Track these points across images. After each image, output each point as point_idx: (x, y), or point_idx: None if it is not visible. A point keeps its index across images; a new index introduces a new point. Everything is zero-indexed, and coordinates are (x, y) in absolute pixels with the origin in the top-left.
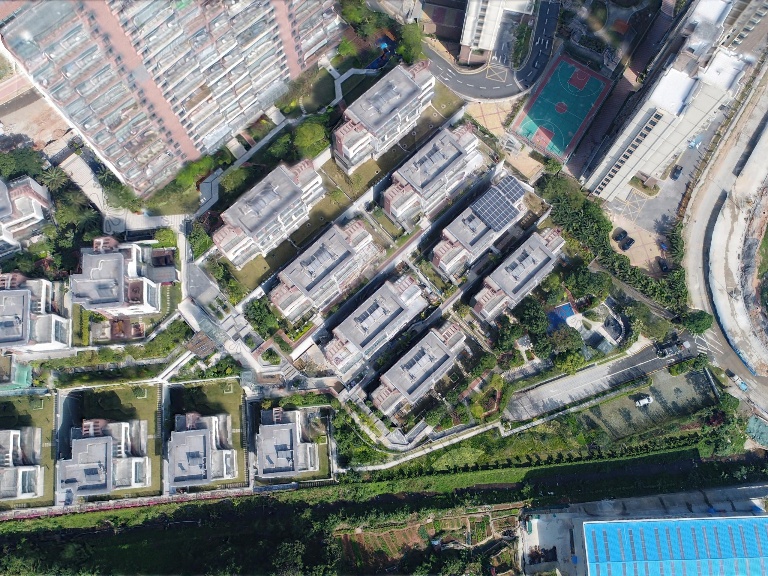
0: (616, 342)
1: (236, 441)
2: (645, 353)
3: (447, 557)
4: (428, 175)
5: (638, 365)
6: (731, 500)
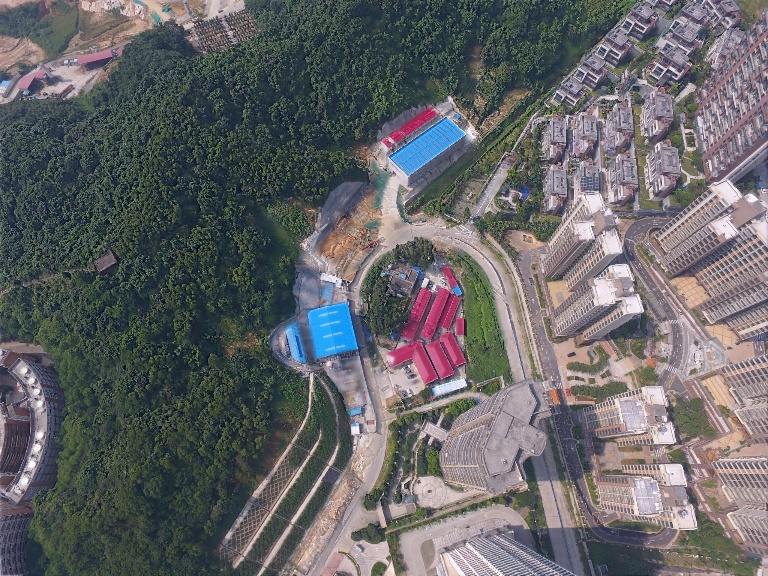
0: (500, 198)
1: (583, 87)
2: (482, 212)
3: (493, 106)
4: (625, 166)
5: (481, 207)
6: (419, 184)
